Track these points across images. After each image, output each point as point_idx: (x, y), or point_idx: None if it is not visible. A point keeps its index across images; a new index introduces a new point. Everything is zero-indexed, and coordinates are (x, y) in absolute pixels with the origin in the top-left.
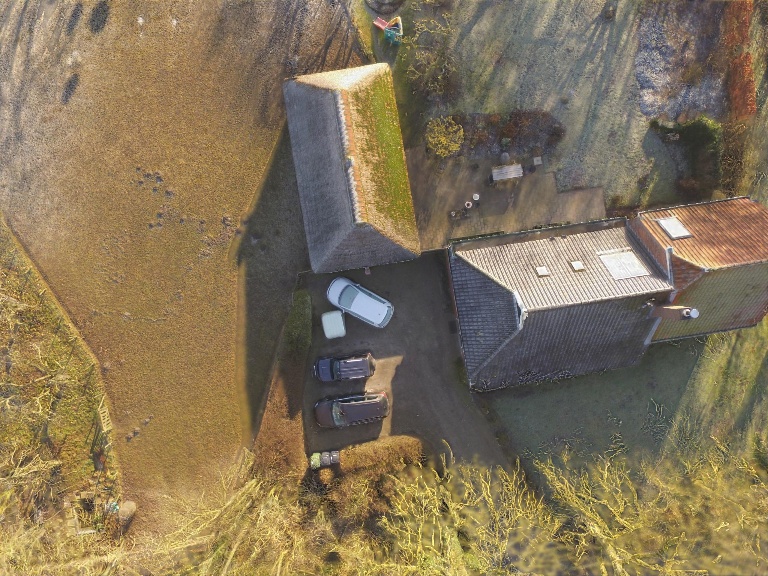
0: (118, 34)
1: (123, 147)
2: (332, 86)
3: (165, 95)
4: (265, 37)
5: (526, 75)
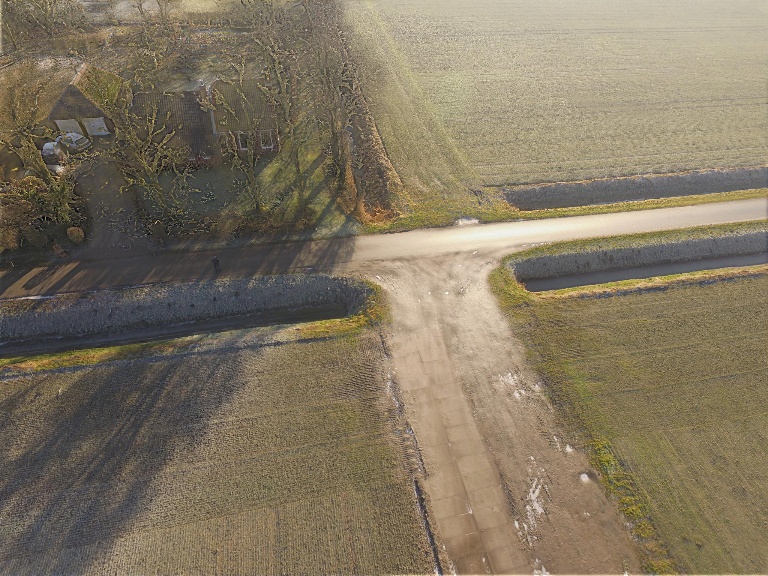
0: None
1: None
2: None
3: None
4: None
5: None
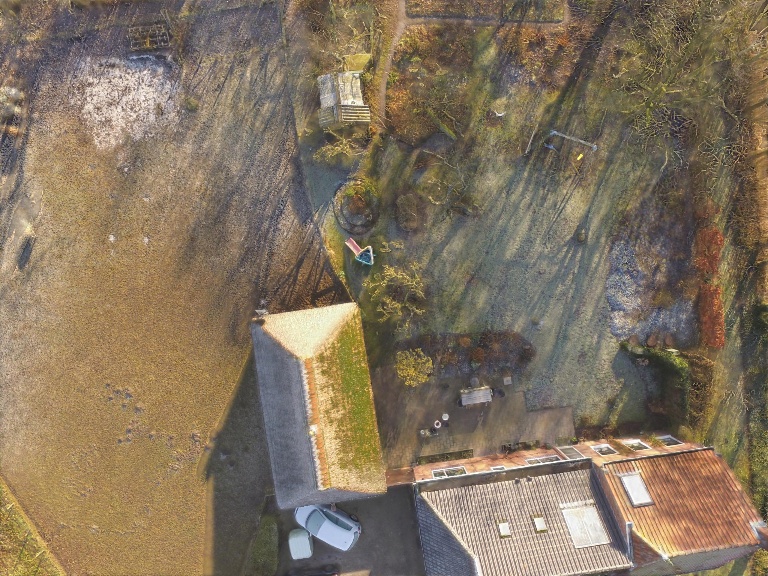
0: (89, 252)
1: (93, 363)
2: (297, 350)
3: (136, 312)
4: (237, 256)
5: (497, 296)
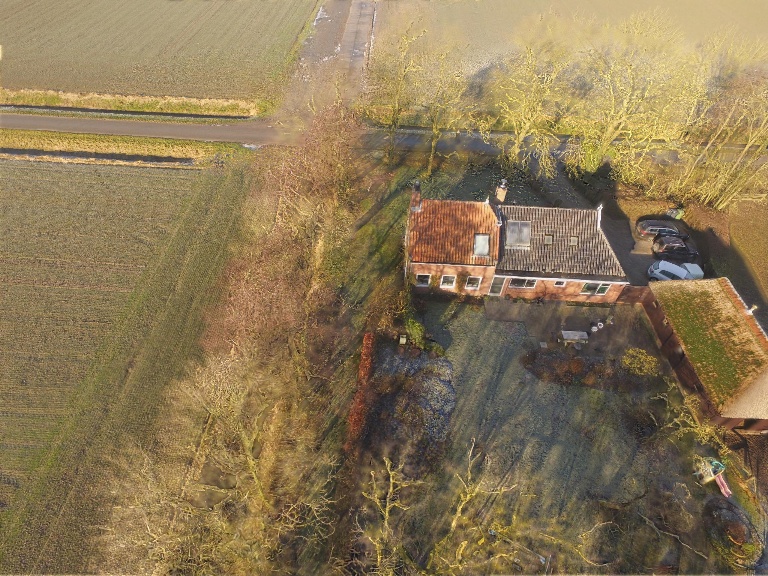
0: None
1: None
2: None
3: None
4: None
5: (560, 413)
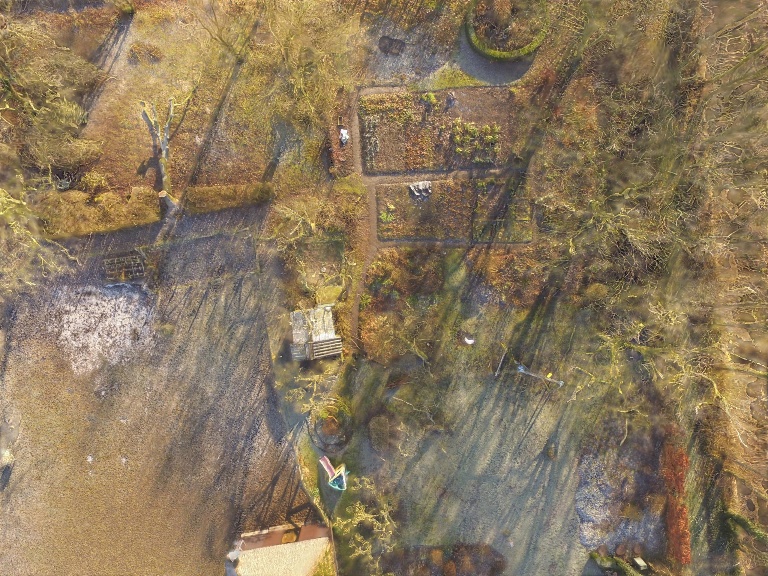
0: (68, 474)
1: None
2: None
3: (114, 530)
4: (213, 474)
5: (469, 509)
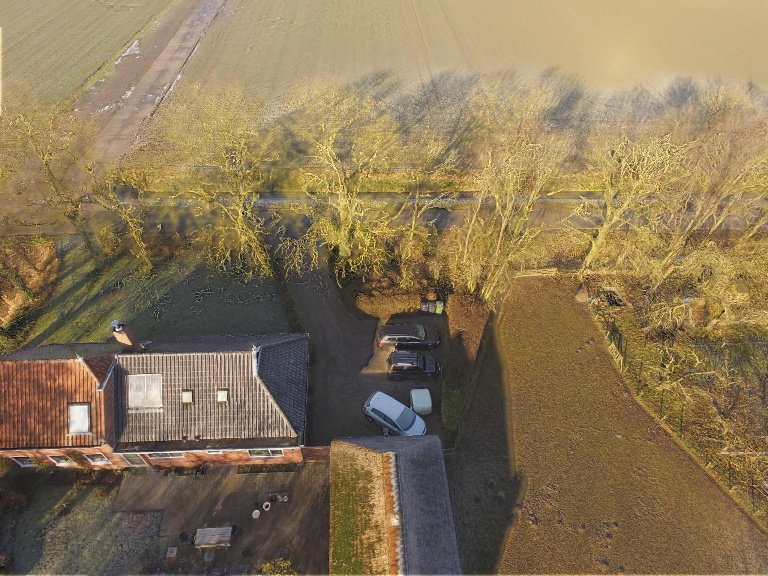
0: None
1: None
2: None
3: None
4: None
5: None
